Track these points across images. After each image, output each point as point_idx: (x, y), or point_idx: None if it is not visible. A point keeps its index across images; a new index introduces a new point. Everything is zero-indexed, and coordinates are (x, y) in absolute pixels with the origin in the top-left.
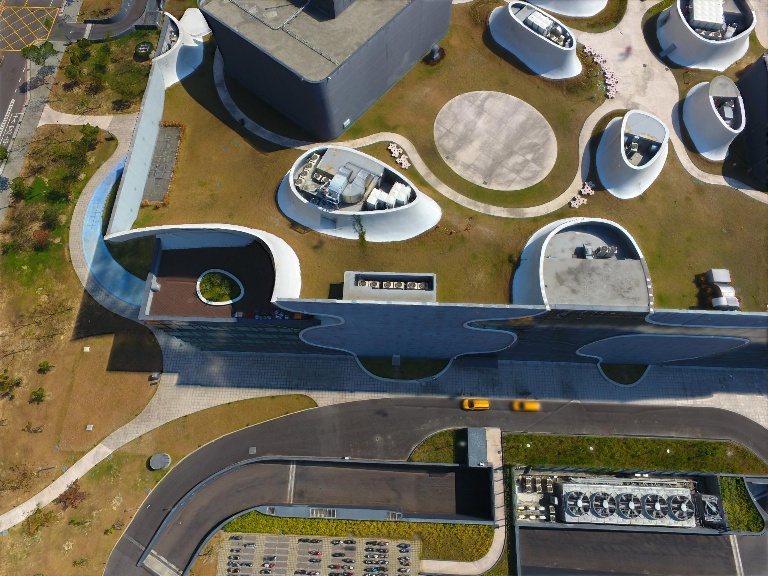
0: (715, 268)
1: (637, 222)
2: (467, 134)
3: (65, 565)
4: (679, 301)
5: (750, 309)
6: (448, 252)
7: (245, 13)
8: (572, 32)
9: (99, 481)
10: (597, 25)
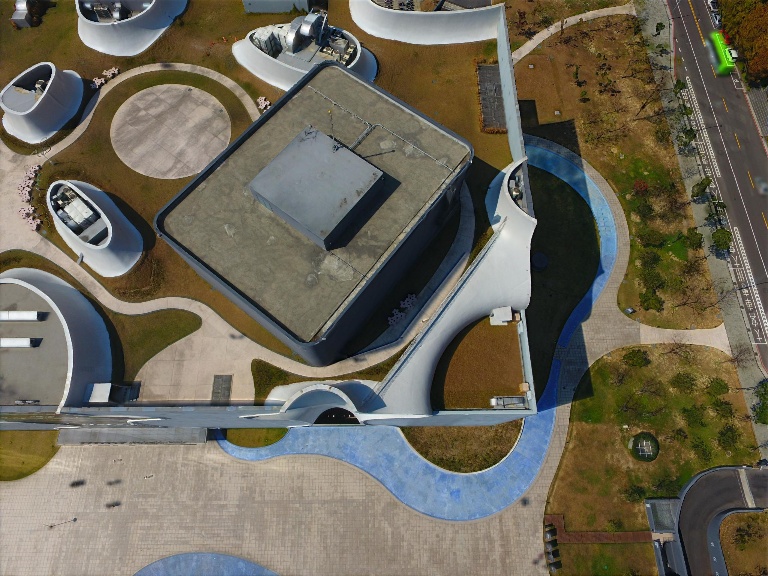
0: (20, 31)
1: (67, 56)
2: (198, 133)
3: (517, 6)
4: (61, 10)
5: (10, 7)
6: (232, 32)
7: (417, 145)
8: (44, 250)
9: (512, 41)
10: (8, 260)
